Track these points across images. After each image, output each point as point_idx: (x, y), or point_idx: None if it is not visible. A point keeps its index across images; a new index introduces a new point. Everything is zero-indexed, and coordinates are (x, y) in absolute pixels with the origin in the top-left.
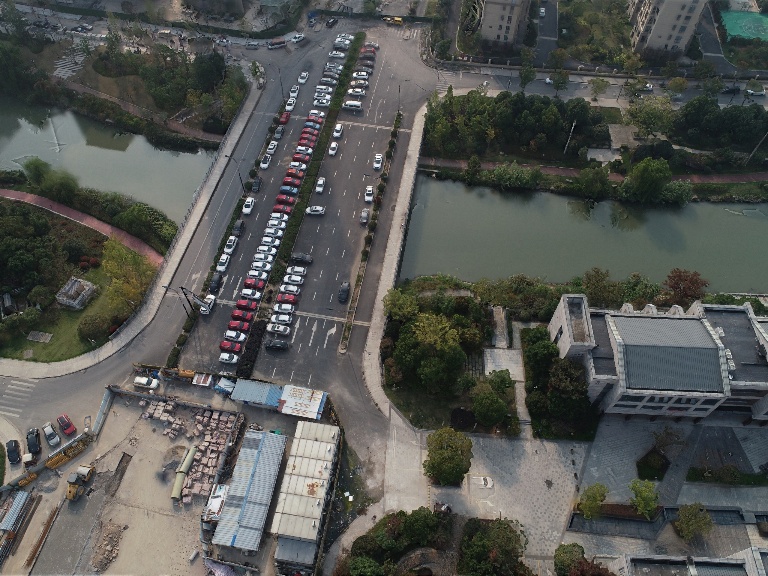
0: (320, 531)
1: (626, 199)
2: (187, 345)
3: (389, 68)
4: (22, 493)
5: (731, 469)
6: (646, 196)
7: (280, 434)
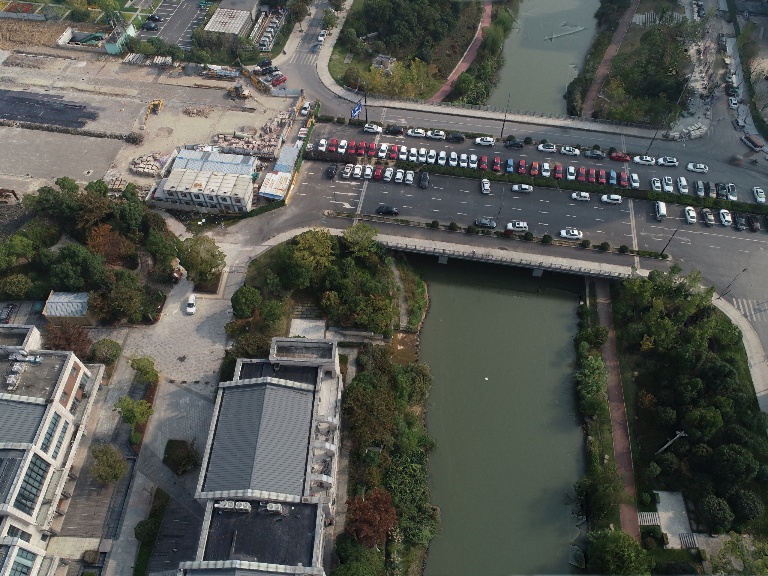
0: (168, 192)
1: (590, 542)
2: (338, 125)
3: (760, 248)
4: (238, 73)
5: (148, 524)
6: (593, 567)
7: (254, 178)
